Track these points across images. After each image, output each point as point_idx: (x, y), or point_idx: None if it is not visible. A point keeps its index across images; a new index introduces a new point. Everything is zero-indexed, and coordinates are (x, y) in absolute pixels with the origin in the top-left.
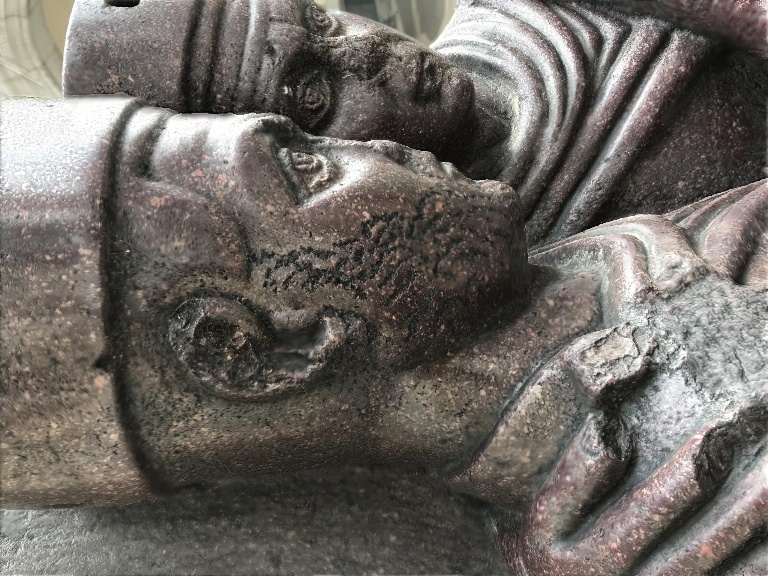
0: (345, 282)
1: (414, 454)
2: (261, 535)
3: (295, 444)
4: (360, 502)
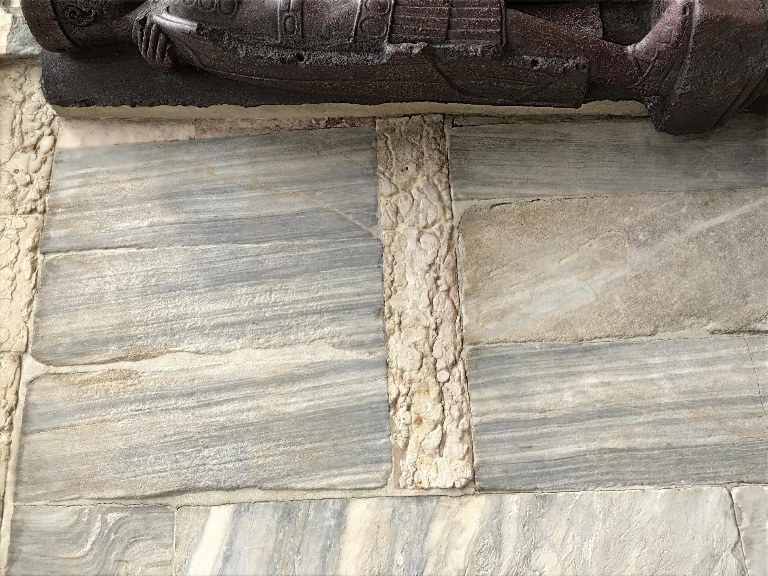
0: (94, 3)
1: (127, 39)
2: (107, 62)
3: (98, 36)
4: (128, 54)
